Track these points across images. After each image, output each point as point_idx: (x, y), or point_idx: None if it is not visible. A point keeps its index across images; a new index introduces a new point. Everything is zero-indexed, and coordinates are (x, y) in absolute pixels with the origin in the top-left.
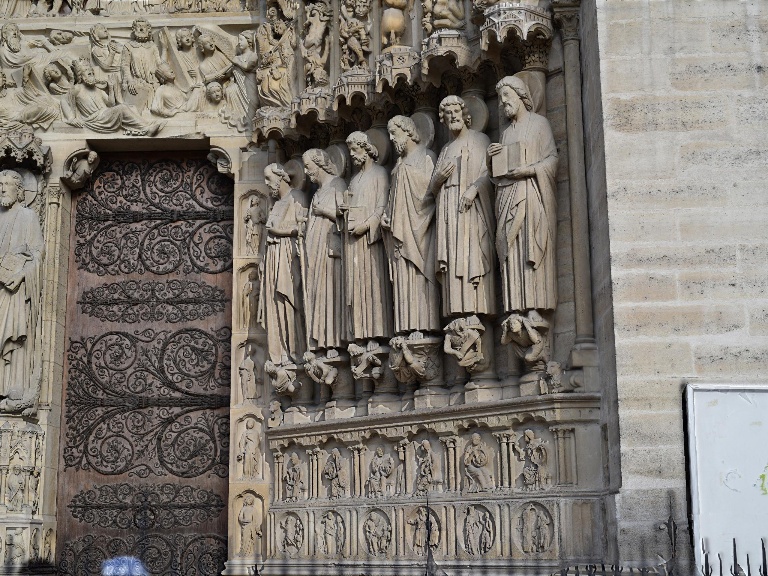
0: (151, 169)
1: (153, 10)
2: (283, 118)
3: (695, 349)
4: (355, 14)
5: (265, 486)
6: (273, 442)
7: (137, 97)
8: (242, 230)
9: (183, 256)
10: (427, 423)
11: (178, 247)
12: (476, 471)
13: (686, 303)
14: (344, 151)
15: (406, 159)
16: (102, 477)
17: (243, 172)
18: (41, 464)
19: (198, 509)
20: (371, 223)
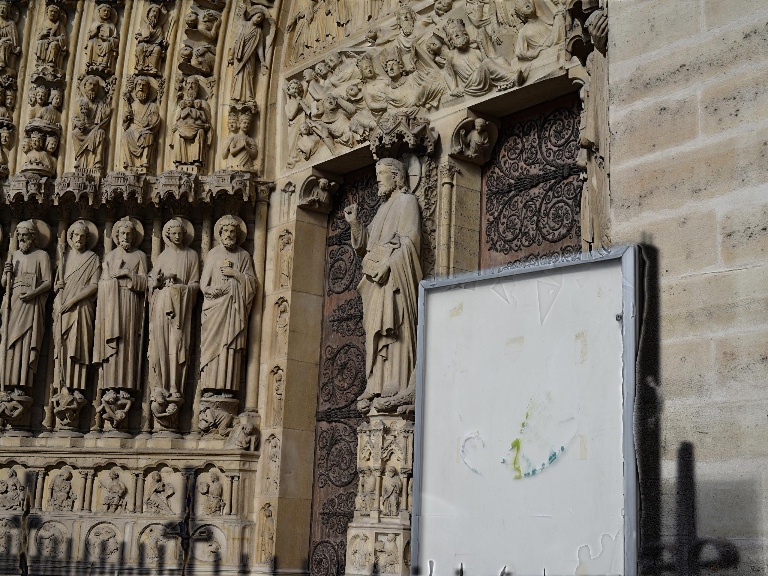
0: (546, 123)
1: None
2: None
3: (722, 220)
4: None
5: None
6: None
7: (503, 46)
8: None
9: (575, 216)
10: None
11: (570, 207)
12: None
13: (711, 139)
14: None
15: None
16: None
17: None
18: None
19: None
20: None
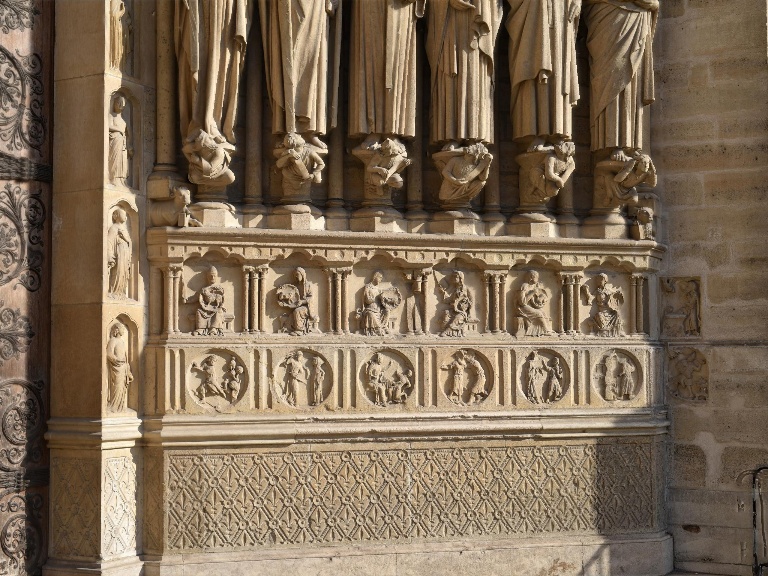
0: None
1: None
2: None
3: None
4: None
5: (140, 310)
6: (178, 248)
7: None
8: None
9: None
10: (474, 252)
11: None
12: (539, 312)
13: None
14: None
15: None
16: None
17: None
18: None
19: (2, 339)
20: None
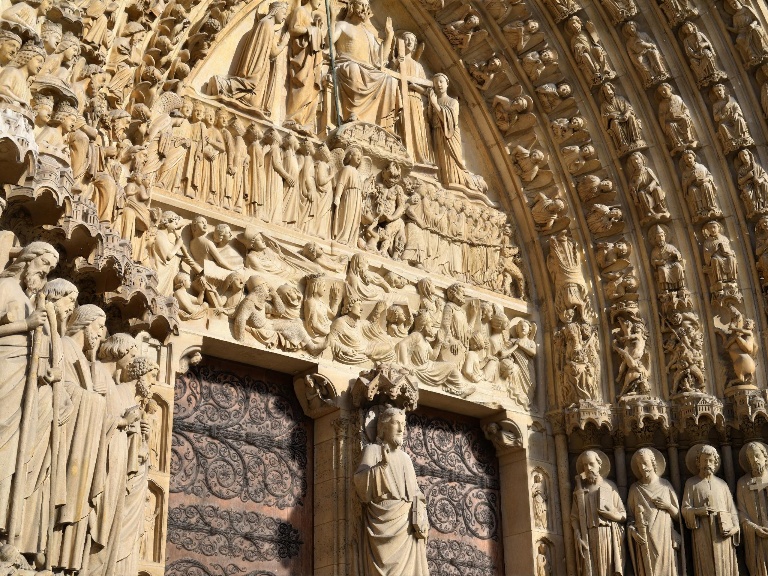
0: (430, 425)
1: (458, 277)
2: (610, 414)
3: None
4: (693, 345)
5: None
6: None
7: (456, 357)
8: None
9: (459, 517)
10: None
11: (456, 508)
12: None
13: None
14: None
15: (763, 479)
16: None
17: None
18: None
19: None
20: (739, 528)
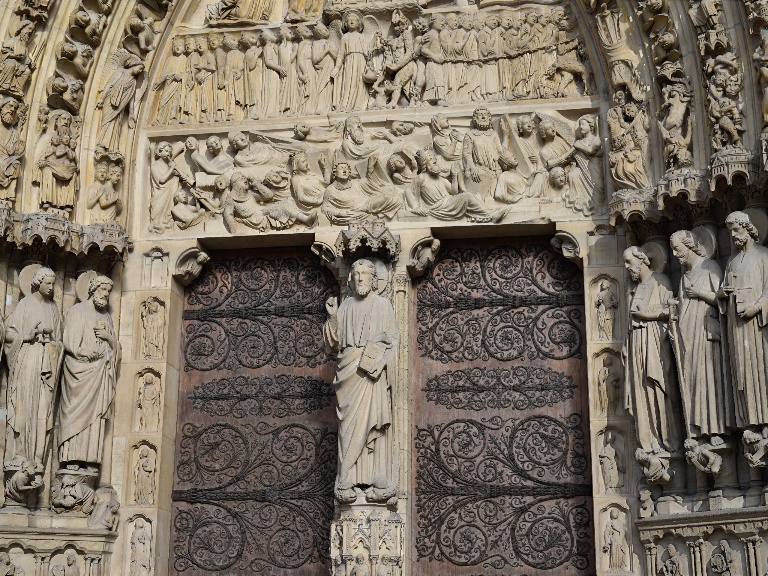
0: (490, 255)
1: (491, 98)
2: (643, 200)
3: None
4: (725, 93)
5: None
6: (645, 533)
7: (480, 184)
8: (593, 315)
9: (527, 342)
10: None
11: (522, 333)
12: None
13: None
14: (712, 232)
15: None
16: (456, 568)
17: (591, 256)
18: (402, 554)
19: None
20: (763, 305)
